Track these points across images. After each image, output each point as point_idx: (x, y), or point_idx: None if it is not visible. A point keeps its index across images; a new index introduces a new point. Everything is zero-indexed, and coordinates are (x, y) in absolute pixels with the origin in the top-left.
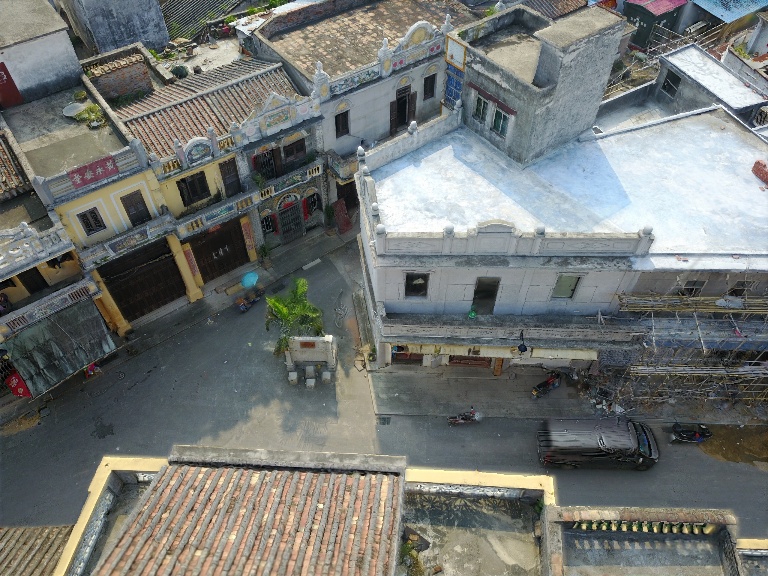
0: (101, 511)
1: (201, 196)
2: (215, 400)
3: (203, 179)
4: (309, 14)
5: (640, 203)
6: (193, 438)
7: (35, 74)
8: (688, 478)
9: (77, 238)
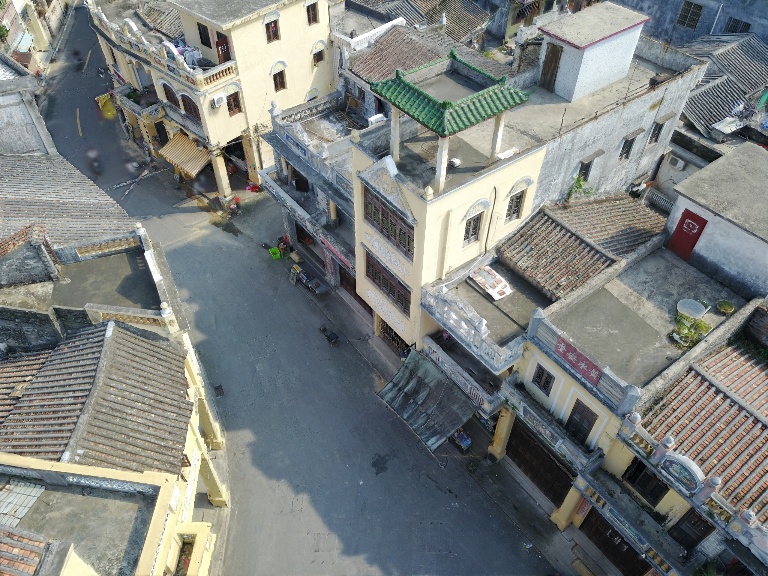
0: (139, 487)
1: (646, 494)
2: (420, 575)
3: (663, 490)
4: None
5: None
6: (373, 558)
7: (722, 254)
8: None
9: (525, 372)
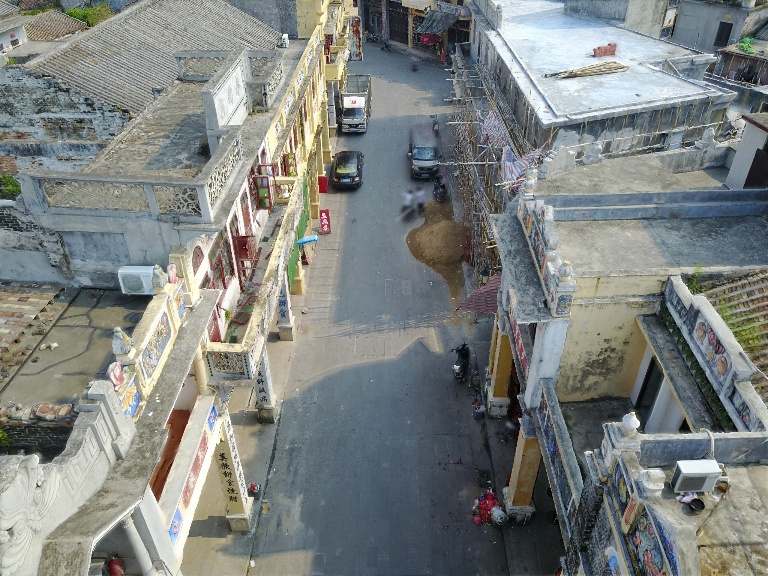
0: None
1: None
2: None
3: None
4: None
5: None
6: (415, 83)
7: None
8: (408, 192)
9: None
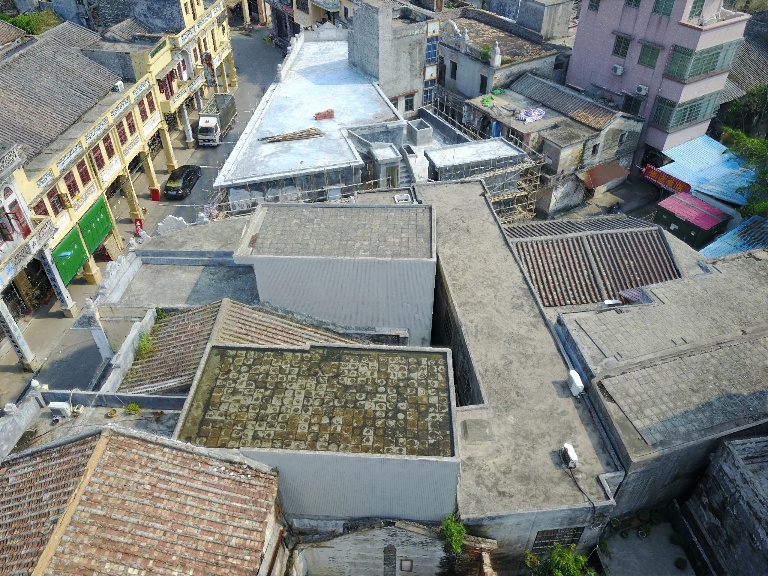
0: None
1: None
2: None
3: None
4: (492, 20)
5: (314, 86)
6: None
7: None
8: None
9: None
